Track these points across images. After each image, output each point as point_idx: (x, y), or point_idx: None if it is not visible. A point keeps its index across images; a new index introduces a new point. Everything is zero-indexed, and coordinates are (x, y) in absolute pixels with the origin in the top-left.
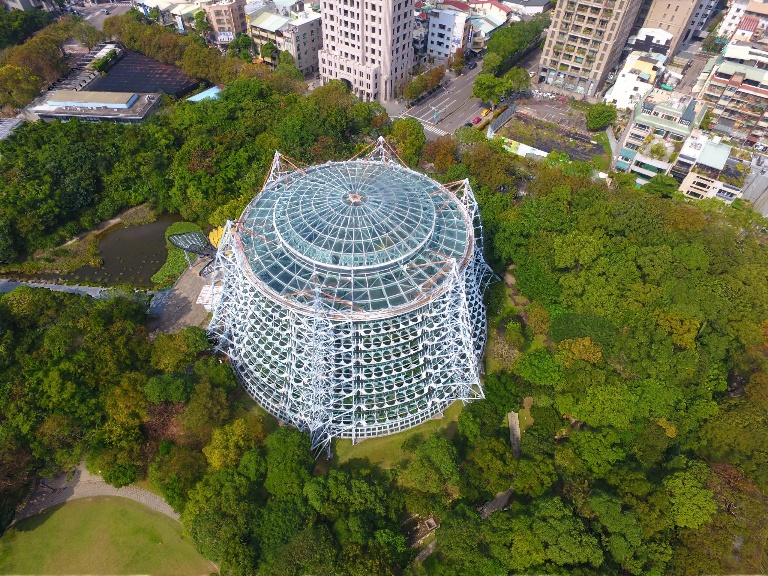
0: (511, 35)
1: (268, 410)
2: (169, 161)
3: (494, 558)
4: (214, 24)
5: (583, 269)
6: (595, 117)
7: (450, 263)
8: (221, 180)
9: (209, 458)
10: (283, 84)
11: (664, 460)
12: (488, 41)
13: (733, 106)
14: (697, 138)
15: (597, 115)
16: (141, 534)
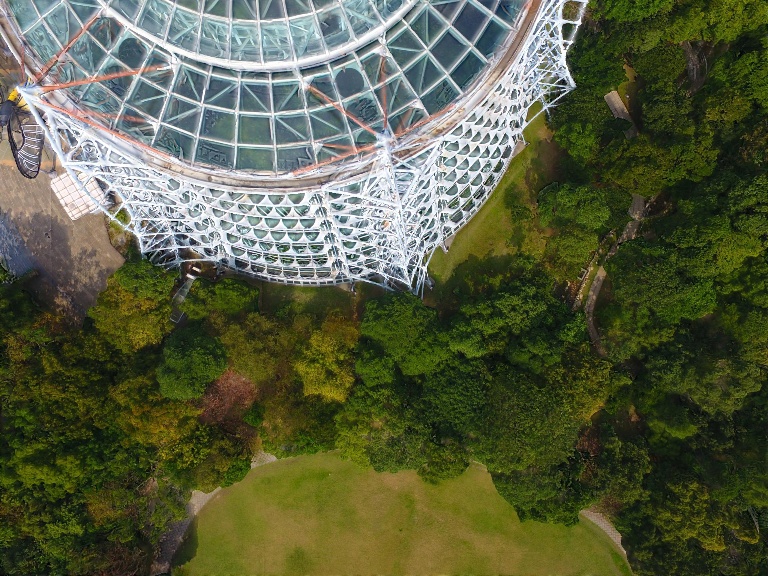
0: None
1: (316, 284)
2: None
3: (697, 280)
4: None
5: None
6: None
7: None
8: None
9: None
10: None
11: None
12: None
13: None
14: None
15: None
16: (304, 482)
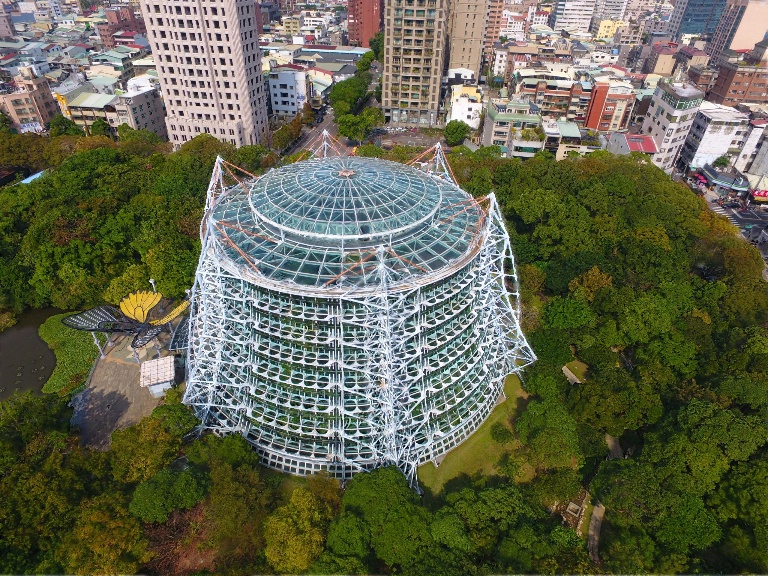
0: (350, 85)
1: None
2: (13, 249)
3: (682, 492)
4: (13, 116)
5: (549, 218)
6: (453, 132)
7: (490, 199)
8: (108, 246)
9: (276, 564)
10: (140, 147)
11: (716, 345)
12: (324, 99)
13: (545, 108)
14: (549, 121)
15: (454, 130)
16: None
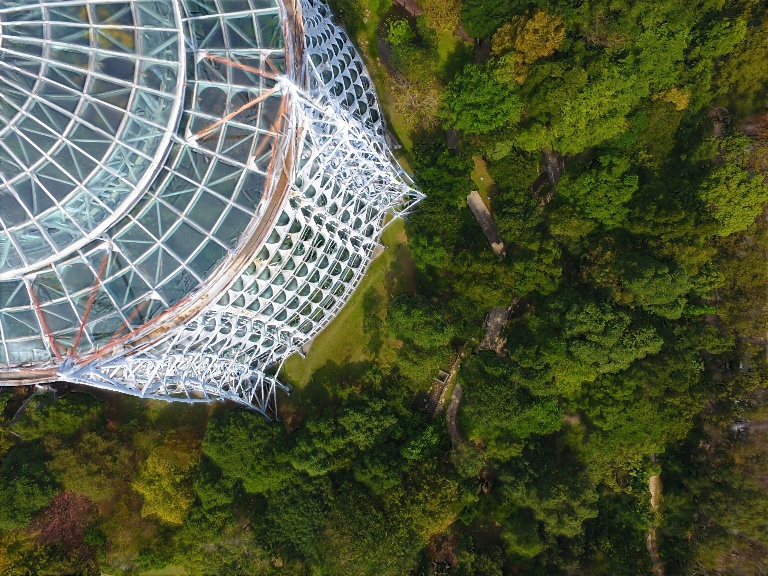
0: None
1: None
2: None
3: (540, 400)
4: None
5: None
6: None
7: None
8: None
9: None
10: None
11: (675, 144)
12: None
13: None
14: None
15: None
16: None
